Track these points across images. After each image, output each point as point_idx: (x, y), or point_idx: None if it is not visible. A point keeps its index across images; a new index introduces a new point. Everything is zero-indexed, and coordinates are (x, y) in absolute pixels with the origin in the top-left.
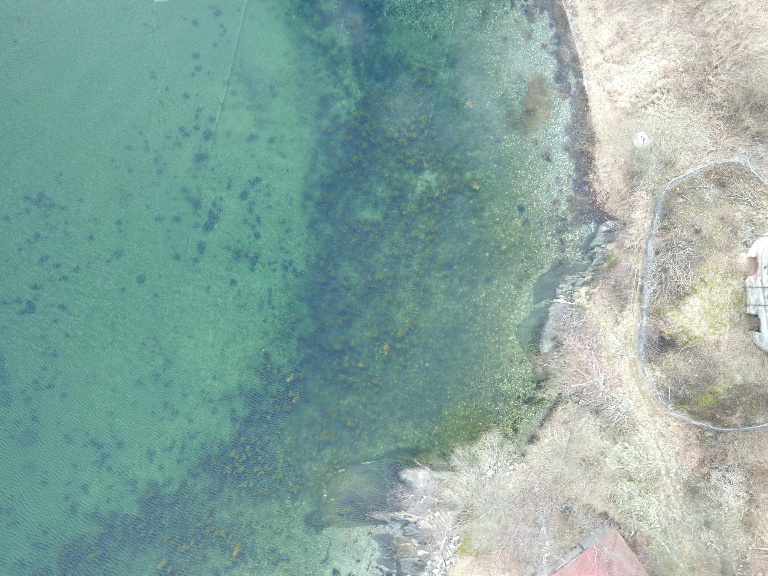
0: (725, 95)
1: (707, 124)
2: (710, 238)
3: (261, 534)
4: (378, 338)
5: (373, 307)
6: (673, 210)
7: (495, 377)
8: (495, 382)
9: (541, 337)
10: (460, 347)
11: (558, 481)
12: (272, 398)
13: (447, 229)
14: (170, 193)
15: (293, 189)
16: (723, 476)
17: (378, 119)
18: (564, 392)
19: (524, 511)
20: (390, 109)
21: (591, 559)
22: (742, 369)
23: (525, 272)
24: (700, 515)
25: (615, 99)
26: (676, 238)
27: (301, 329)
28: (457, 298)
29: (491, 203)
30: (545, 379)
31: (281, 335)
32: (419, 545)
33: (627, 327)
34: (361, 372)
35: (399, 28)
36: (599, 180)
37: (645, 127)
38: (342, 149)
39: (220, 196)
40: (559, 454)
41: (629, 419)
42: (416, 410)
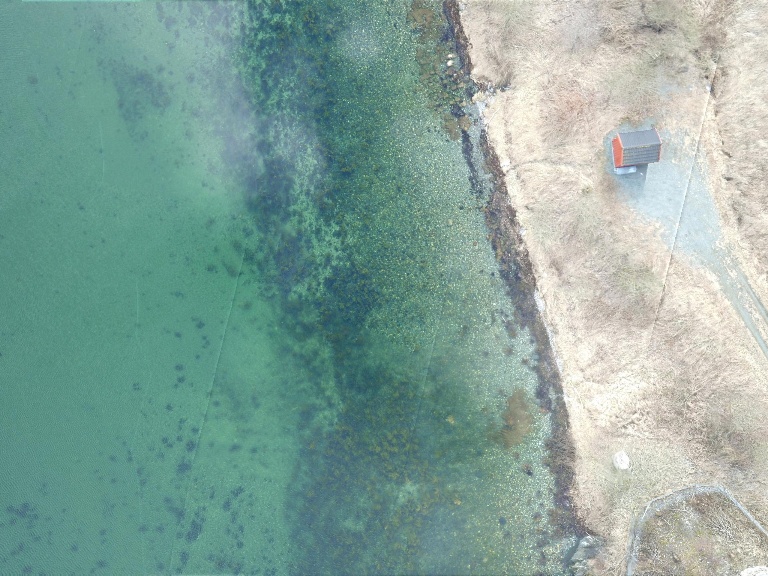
0: (704, 420)
1: (686, 447)
2: (689, 571)
3: None
4: None
5: None
6: (653, 533)
7: None
8: None
9: None
10: None
11: None
12: None
13: (429, 541)
14: (153, 504)
15: (276, 499)
16: None
17: (360, 430)
18: None
19: None
20: (372, 422)
21: None
22: None
23: None
24: None
25: (595, 417)
26: (655, 567)
27: None
28: None
29: (473, 515)
30: None
31: None
32: None
33: None
34: None
35: (381, 341)
36: (580, 495)
37: (625, 446)
38: (324, 460)
39: (203, 506)
40: None
41: None
42: None
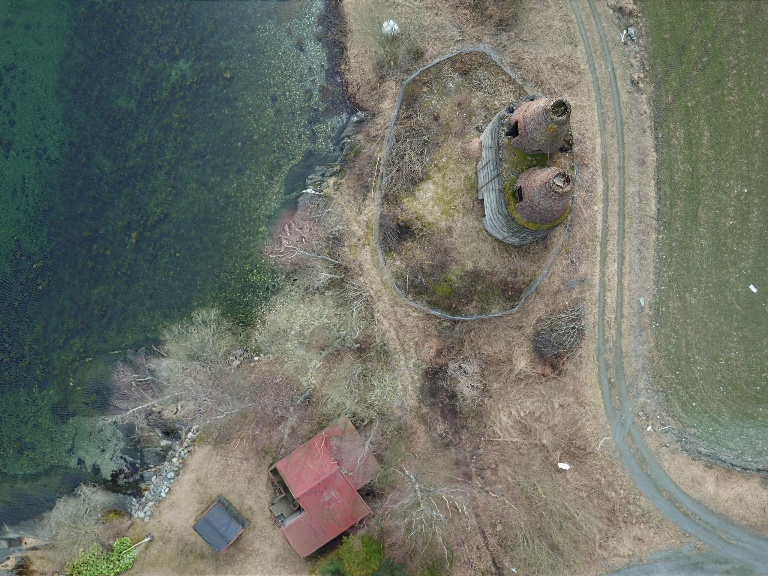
0: None
1: (454, 13)
2: (446, 124)
3: (8, 423)
4: (130, 227)
5: (125, 196)
6: (418, 99)
7: (245, 268)
8: (245, 273)
9: (290, 228)
10: (211, 237)
11: (299, 371)
12: (21, 285)
13: (200, 118)
14: None
15: (49, 76)
16: (459, 367)
17: (134, 7)
18: (310, 283)
19: (264, 401)
20: None
21: (318, 445)
22: (473, 256)
23: (277, 163)
24: (436, 406)
25: None
26: (415, 125)
27: (53, 217)
28: (209, 188)
29: (244, 93)
30: (294, 270)
31: (33, 223)
32: (162, 435)
33: (369, 216)
34: (112, 261)
35: None
36: (351, 70)
37: (395, 16)
38: (98, 37)
39: None
40: None
41: (368, 308)
42: (165, 300)
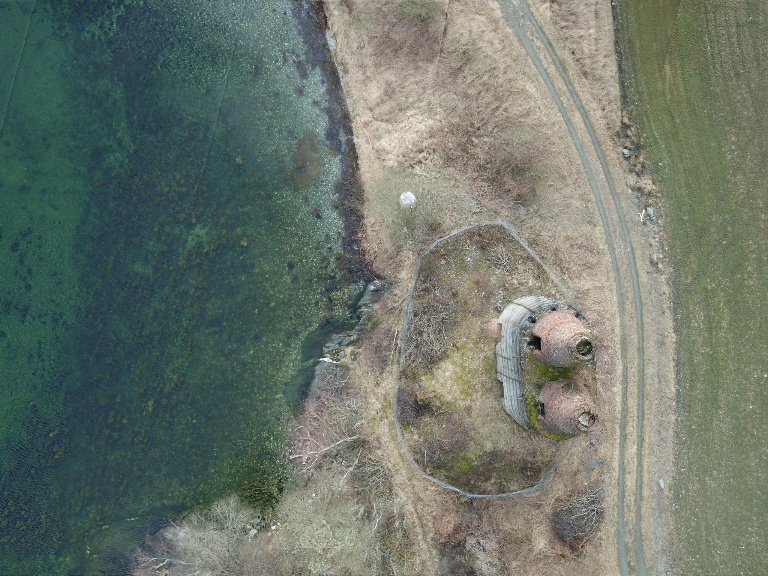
0: (488, 157)
1: (472, 185)
2: (465, 302)
3: None
4: (146, 393)
5: (141, 362)
6: (435, 271)
7: (262, 435)
8: (262, 440)
9: (307, 396)
10: (227, 404)
11: None
12: (37, 452)
13: (217, 285)
14: None
15: (65, 241)
16: (478, 542)
17: (151, 172)
18: None
19: (282, 573)
20: (161, 163)
21: None
22: (492, 436)
23: (294, 330)
24: None
25: (383, 158)
26: (433, 301)
27: (69, 383)
28: (225, 354)
29: (261, 259)
30: None
31: (49, 388)
32: None
33: (386, 389)
34: (128, 427)
35: (173, 82)
36: (368, 238)
37: (412, 186)
38: (114, 202)
39: None
40: (319, 515)
41: (386, 482)
42: (182, 467)
